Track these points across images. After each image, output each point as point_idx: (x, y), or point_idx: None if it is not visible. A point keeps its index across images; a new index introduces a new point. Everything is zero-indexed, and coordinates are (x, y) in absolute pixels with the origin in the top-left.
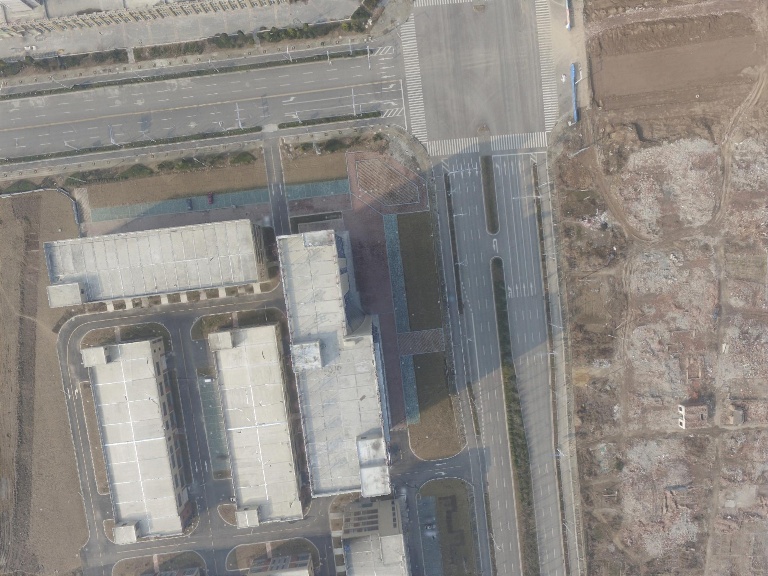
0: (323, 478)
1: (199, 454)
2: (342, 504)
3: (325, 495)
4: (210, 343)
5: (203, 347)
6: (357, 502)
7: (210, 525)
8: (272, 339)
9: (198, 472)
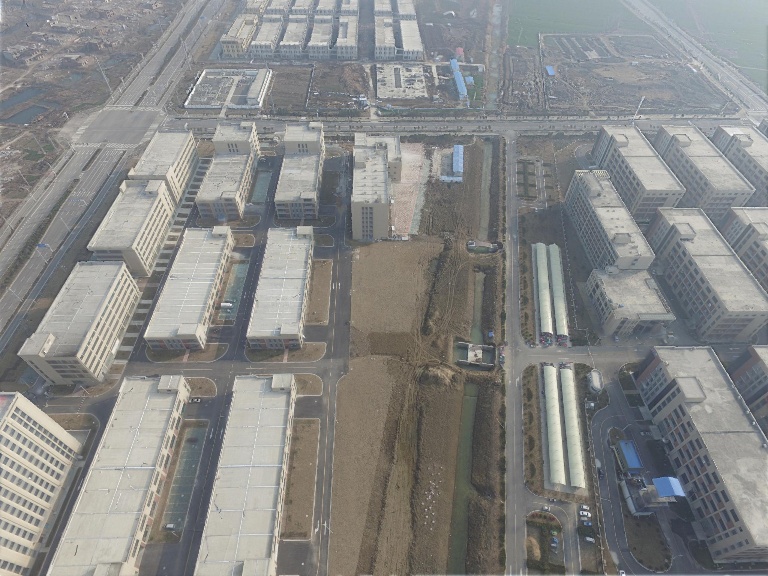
0: (0, 408)
1: (214, 446)
2: (103, 386)
3: (5, 393)
4: (119, 573)
5: (161, 570)
6: (88, 386)
7: (229, 381)
8: (56, 571)
9: (222, 429)
